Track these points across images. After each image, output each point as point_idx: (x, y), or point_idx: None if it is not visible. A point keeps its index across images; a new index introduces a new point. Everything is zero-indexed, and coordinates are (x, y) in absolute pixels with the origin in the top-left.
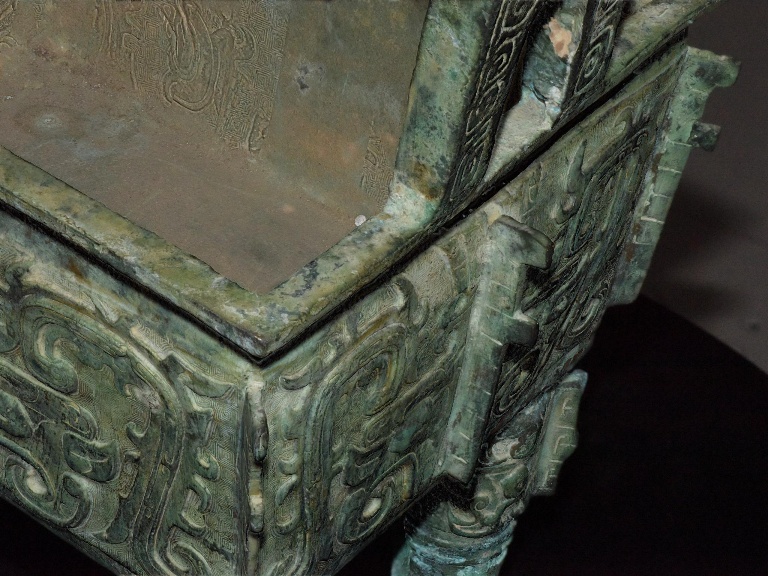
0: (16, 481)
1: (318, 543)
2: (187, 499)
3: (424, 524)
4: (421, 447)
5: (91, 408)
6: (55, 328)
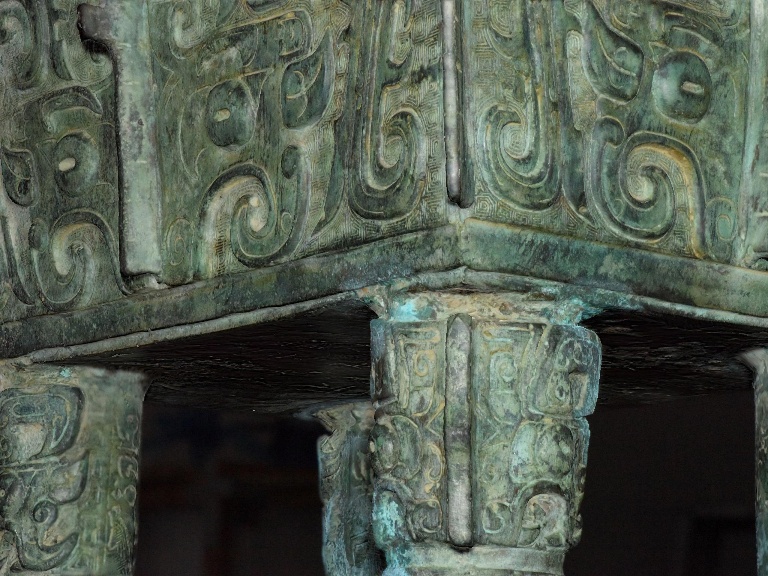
0: (240, 236)
1: (558, 143)
2: (394, 29)
3: None
4: (707, 163)
5: None
6: None
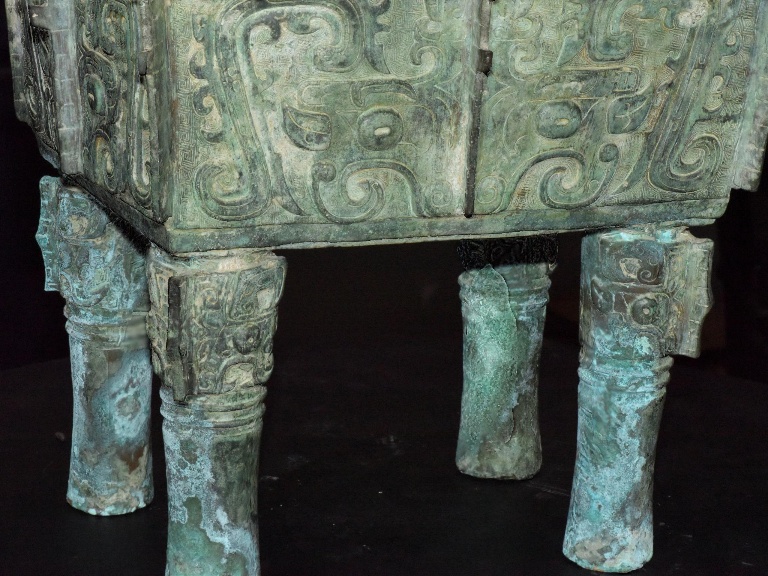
0: (551, 191)
1: None
2: (709, 90)
3: (526, 281)
4: None
5: (640, 61)
6: (625, 2)
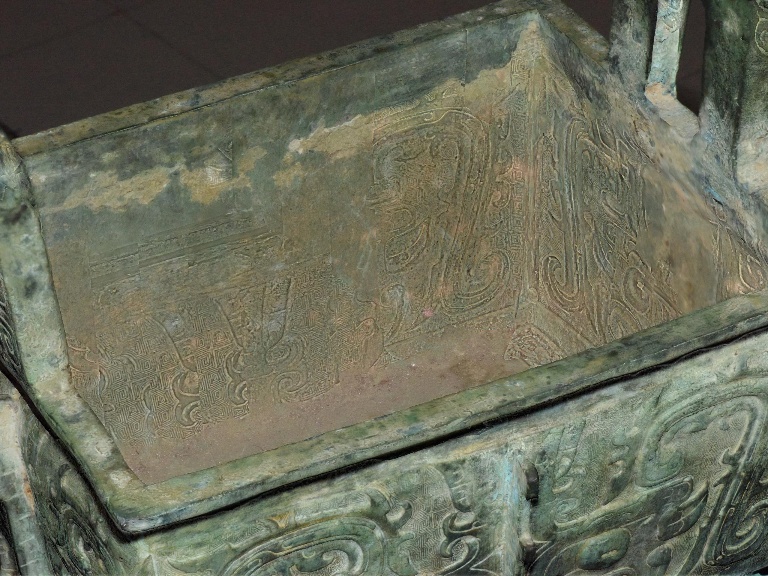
0: None
1: None
2: None
3: None
4: None
5: None
6: None
